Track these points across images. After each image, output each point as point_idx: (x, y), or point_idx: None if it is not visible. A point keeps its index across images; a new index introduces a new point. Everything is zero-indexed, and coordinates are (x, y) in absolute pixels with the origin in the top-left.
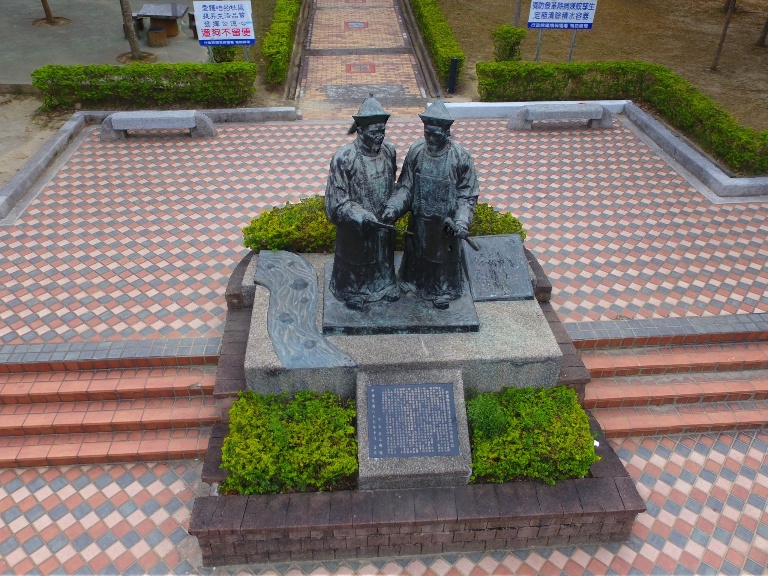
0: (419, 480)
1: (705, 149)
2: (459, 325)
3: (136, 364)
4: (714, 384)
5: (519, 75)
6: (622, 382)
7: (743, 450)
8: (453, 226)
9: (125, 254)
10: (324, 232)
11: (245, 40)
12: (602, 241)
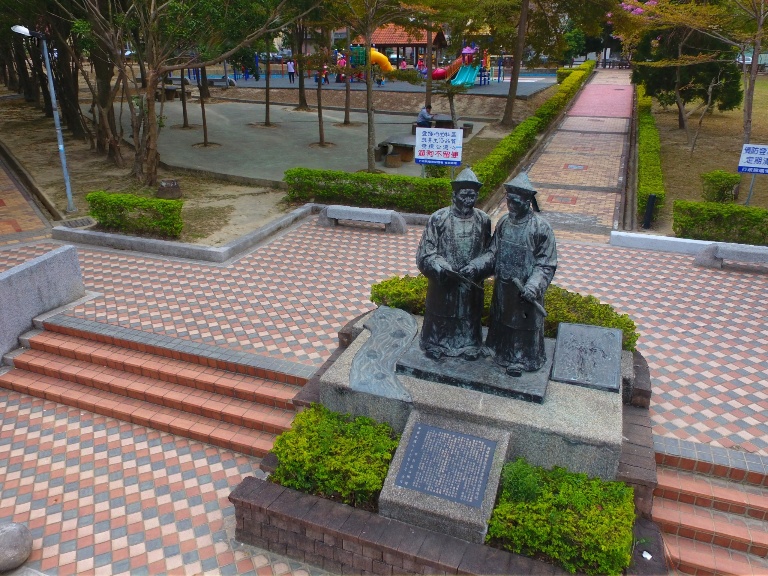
0: (435, 521)
1: None
2: (522, 392)
3: (256, 373)
4: None
5: (720, 216)
6: (719, 516)
7: None
8: (520, 286)
9: (290, 299)
10: None
11: (453, 161)
12: (753, 376)
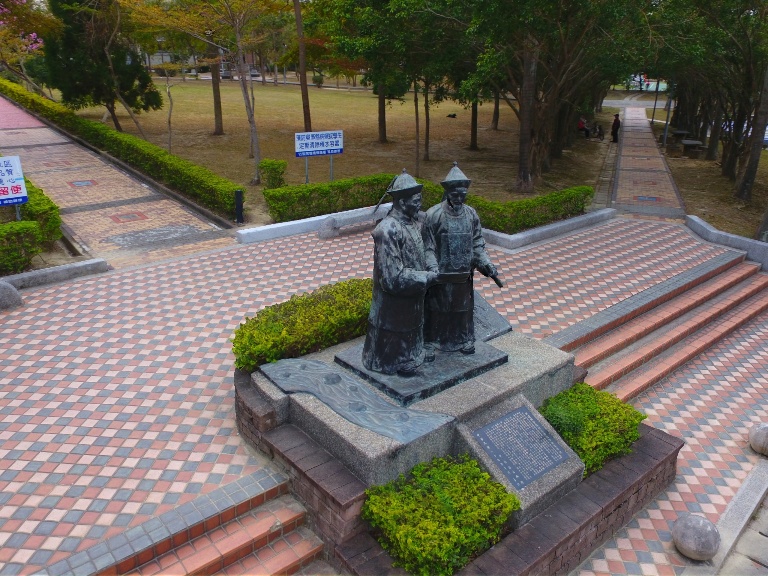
0: (556, 493)
1: None
2: (497, 359)
3: (189, 536)
4: (623, 360)
5: (303, 196)
6: None
7: (666, 396)
8: (490, 268)
9: (45, 440)
10: (316, 329)
11: (15, 198)
12: None
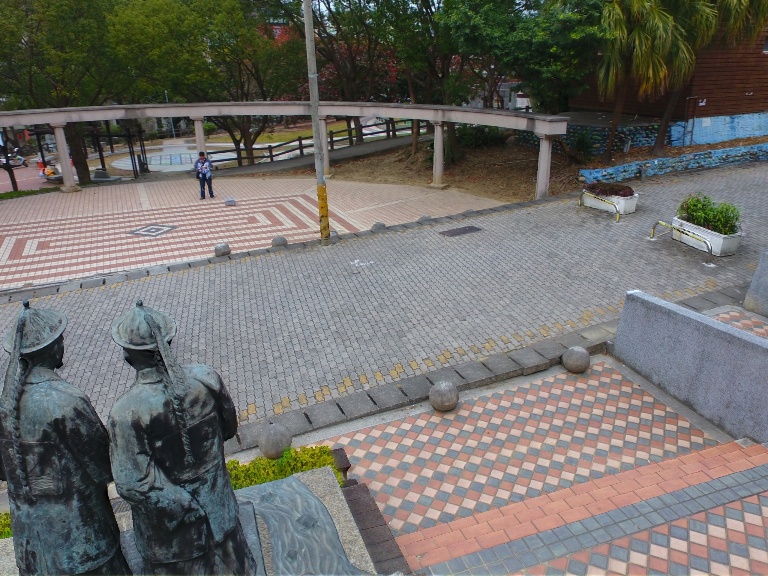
0: None
1: None
2: None
3: None
4: None
5: None
6: None
7: None
8: None
9: None
10: None
11: None
12: None
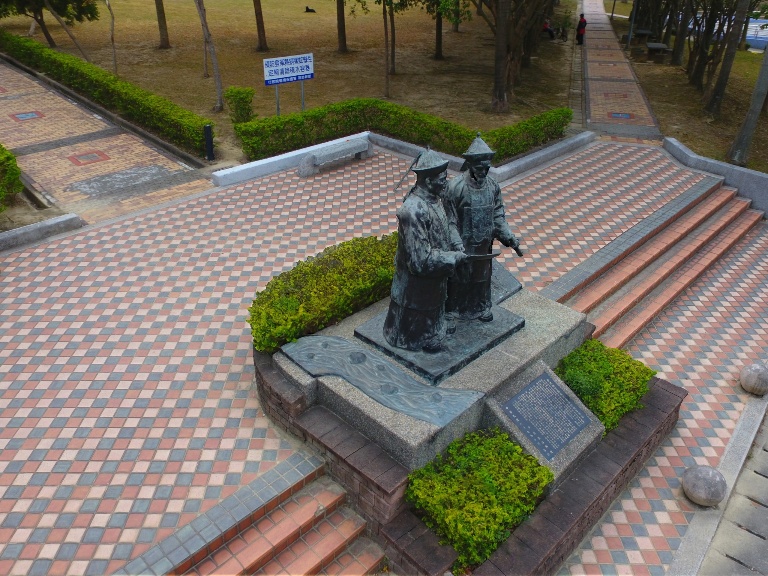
0: (581, 457)
1: (450, 154)
2: (516, 326)
3: (238, 530)
4: (619, 303)
5: (277, 129)
6: None
7: (659, 337)
8: None
9: (67, 436)
10: (333, 303)
11: None
12: None
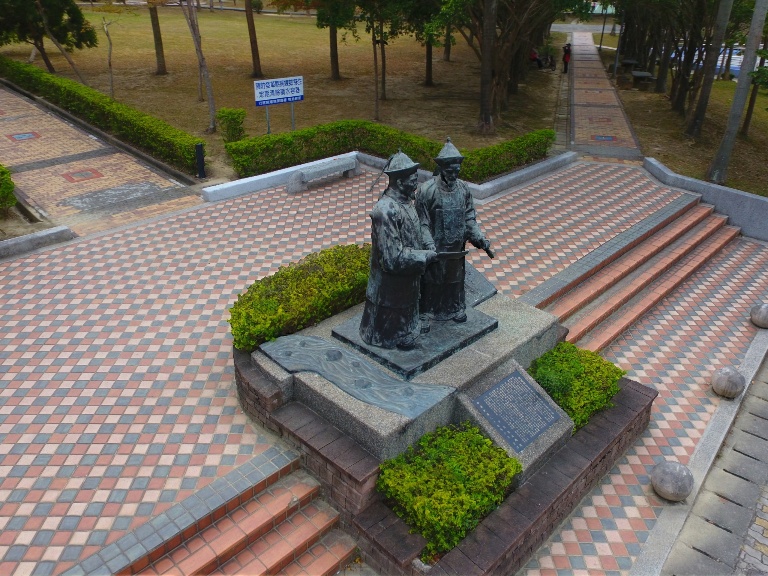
0: (550, 452)
1: None
2: (489, 326)
3: (212, 519)
4: (595, 311)
5: (267, 148)
6: None
7: (635, 344)
8: (484, 241)
9: (48, 431)
10: (311, 304)
11: None
12: None
